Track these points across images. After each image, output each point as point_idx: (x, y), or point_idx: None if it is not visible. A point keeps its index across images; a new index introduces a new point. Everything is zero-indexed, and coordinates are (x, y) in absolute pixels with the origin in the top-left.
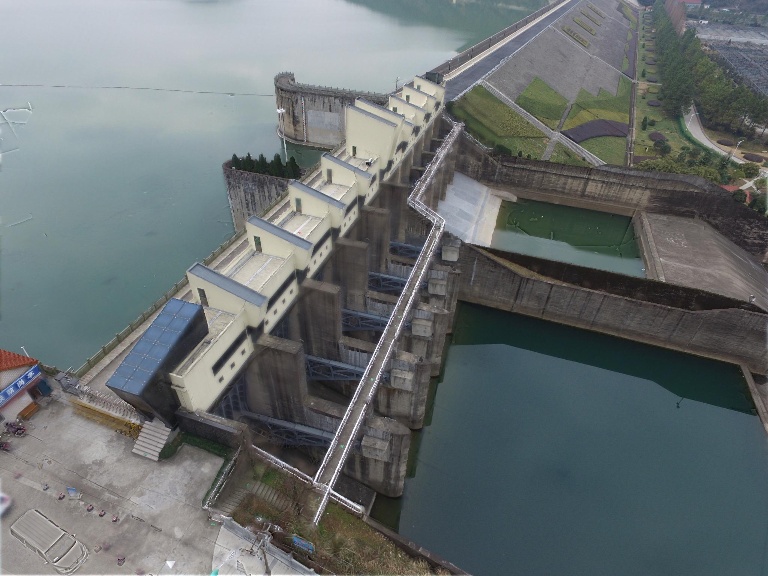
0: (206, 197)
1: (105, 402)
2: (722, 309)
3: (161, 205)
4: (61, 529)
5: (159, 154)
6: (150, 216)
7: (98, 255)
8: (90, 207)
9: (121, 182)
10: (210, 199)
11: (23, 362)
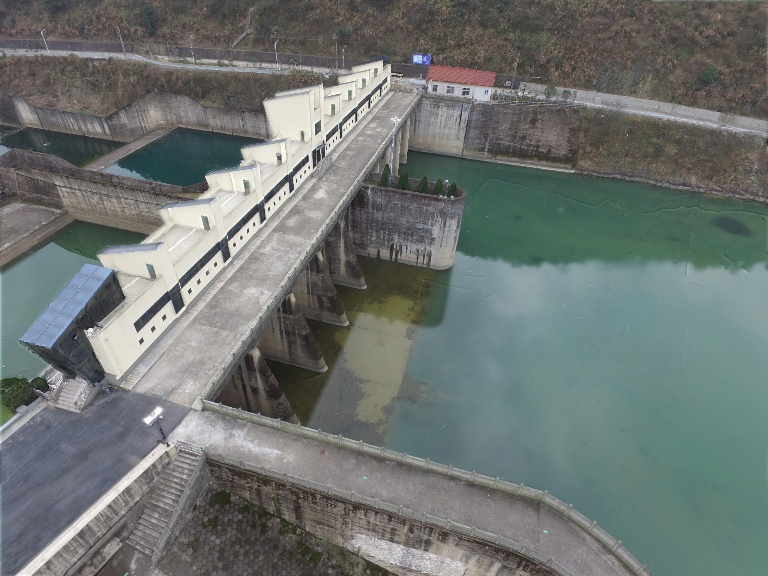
0: (534, 317)
1: (405, 92)
2: (62, 160)
3: (578, 304)
4: (391, 75)
5: (763, 458)
6: (568, 284)
7: (557, 239)
8: (653, 295)
9: (691, 348)
10: (527, 317)
11: (429, 75)
